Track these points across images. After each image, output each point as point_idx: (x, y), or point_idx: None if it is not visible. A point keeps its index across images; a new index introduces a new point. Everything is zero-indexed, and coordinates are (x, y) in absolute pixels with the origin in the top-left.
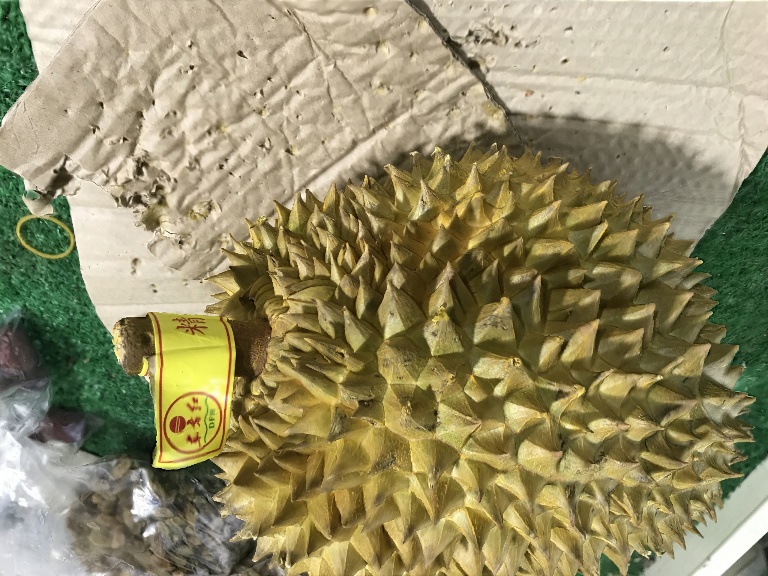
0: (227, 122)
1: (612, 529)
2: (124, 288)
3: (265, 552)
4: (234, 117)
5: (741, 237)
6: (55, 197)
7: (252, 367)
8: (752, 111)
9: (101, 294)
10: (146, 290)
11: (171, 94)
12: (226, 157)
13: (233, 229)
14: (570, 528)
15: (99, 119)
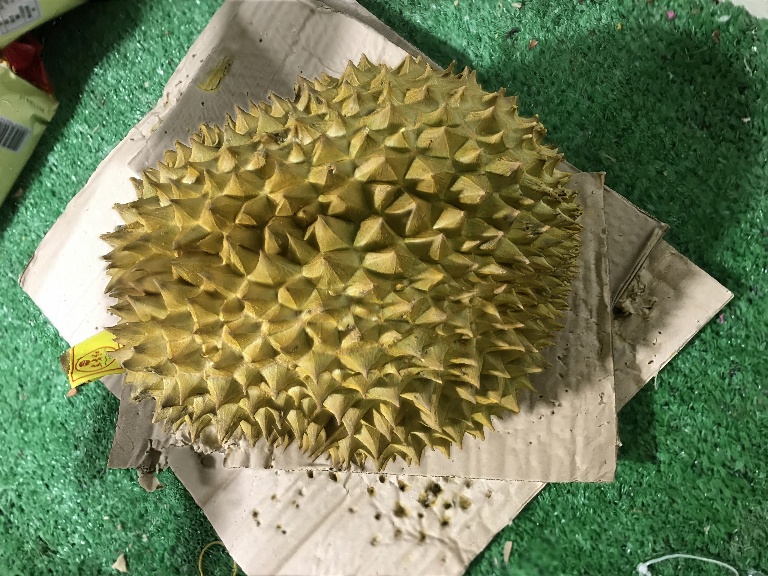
0: None
1: (316, 147)
2: (262, 546)
3: (164, 397)
4: None
5: (547, 94)
6: (157, 472)
7: None
8: (389, 63)
9: (254, 567)
10: (277, 535)
11: None
12: None
13: None
14: (260, 163)
15: None
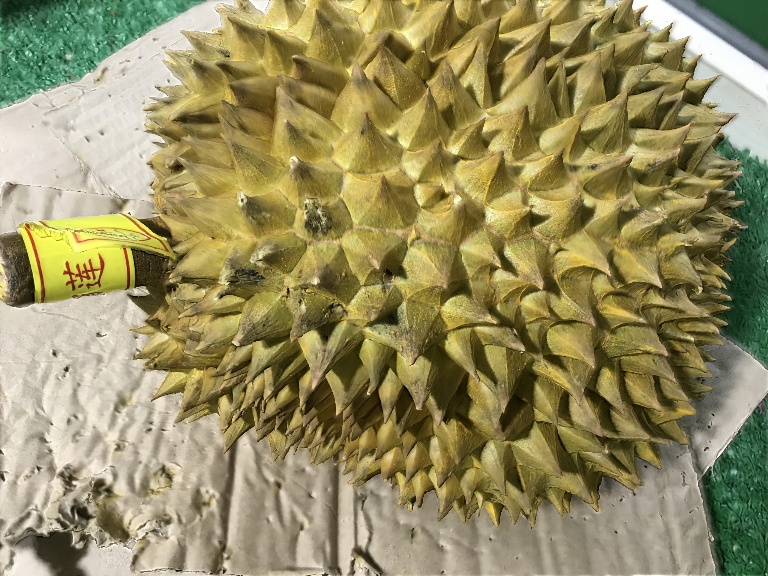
0: (127, 393)
1: None
2: None
3: (317, 268)
4: (130, 384)
5: None
6: None
7: (160, 227)
8: None
9: None
10: None
11: (61, 402)
12: (149, 421)
13: (206, 476)
14: None
15: (3, 465)
